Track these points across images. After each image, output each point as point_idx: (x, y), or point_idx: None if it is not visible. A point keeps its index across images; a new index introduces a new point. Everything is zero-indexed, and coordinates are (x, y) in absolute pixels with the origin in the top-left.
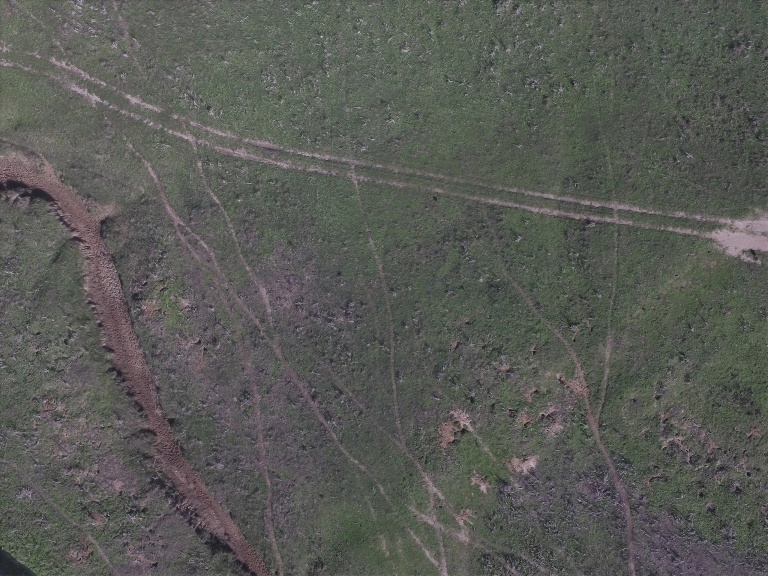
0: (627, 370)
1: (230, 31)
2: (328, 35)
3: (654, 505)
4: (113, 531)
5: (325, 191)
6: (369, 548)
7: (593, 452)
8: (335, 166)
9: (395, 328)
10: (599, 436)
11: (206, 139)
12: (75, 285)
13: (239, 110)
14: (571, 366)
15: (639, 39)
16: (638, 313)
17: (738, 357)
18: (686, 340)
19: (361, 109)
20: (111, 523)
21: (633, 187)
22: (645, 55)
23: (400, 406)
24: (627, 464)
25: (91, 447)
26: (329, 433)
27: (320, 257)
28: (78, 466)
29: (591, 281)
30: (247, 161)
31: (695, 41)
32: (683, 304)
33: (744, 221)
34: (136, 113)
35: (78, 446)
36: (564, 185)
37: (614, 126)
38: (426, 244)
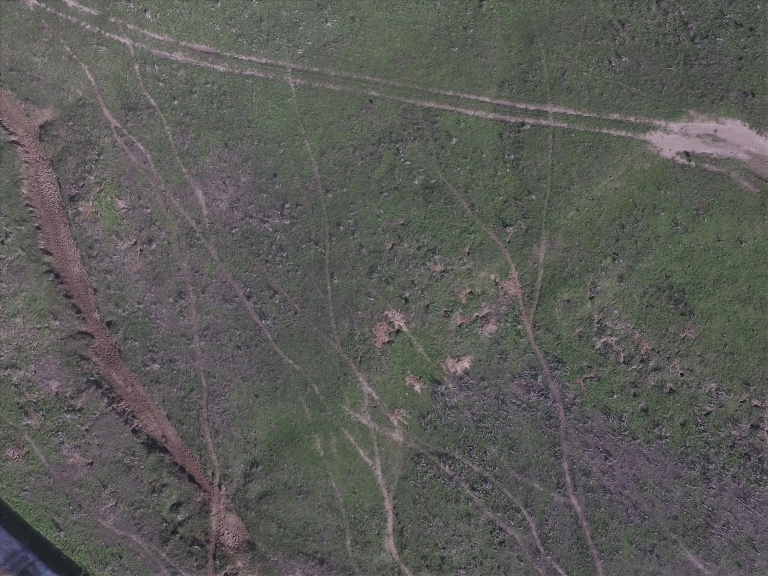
0: (561, 271)
1: None
2: None
3: (587, 405)
4: (49, 430)
5: (261, 94)
6: (304, 447)
7: (527, 352)
8: (272, 69)
9: (330, 229)
10: (533, 337)
11: (143, 42)
12: (13, 187)
13: (176, 13)
14: (505, 267)
15: None
16: (572, 214)
17: (672, 258)
18: (619, 240)
19: (298, 13)
20: (47, 422)
21: (568, 90)
22: None
23: (335, 307)
24: (560, 364)
25: (28, 348)
26: (264, 333)
27: (256, 159)
28: (15, 366)
29: (526, 183)
30: (184, 64)
31: None
32: (617, 205)
33: (678, 123)
34: (73, 16)
35: (15, 346)
36: (500, 88)
37: (550, 29)
38: (362, 146)
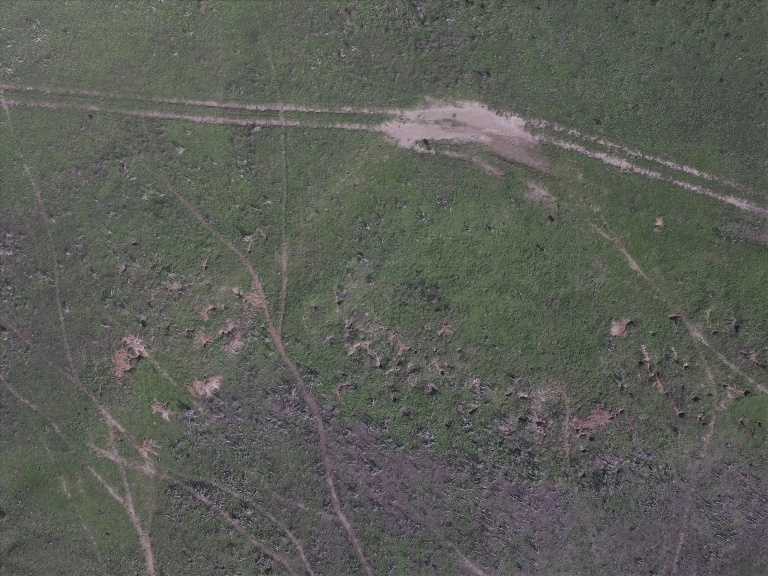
0: (305, 277)
1: None
2: None
3: (346, 415)
4: None
5: None
6: (49, 491)
7: (278, 366)
8: None
9: (58, 257)
10: (283, 349)
11: None
12: None
13: None
14: (247, 278)
15: None
16: (312, 216)
17: (421, 252)
18: (362, 239)
19: (5, 30)
20: None
21: (297, 86)
22: None
23: (69, 338)
24: (312, 374)
25: None
26: None
27: None
28: None
29: (261, 188)
30: None
31: None
32: (358, 202)
33: (415, 111)
34: None
35: None
36: (227, 91)
37: (274, 25)
38: (84, 165)
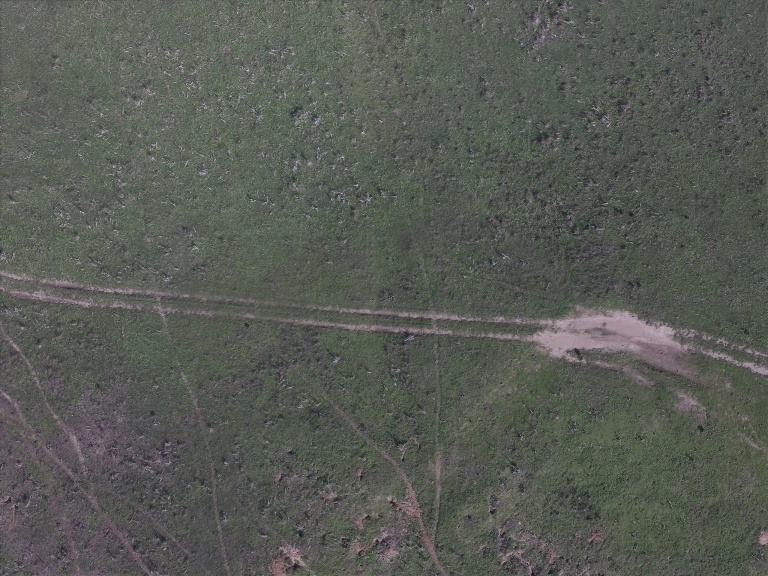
0: (459, 486)
1: (17, 169)
2: (121, 164)
3: None
4: None
5: (131, 327)
6: None
7: (432, 575)
8: (140, 300)
9: (215, 465)
10: (437, 557)
11: (0, 284)
12: None
13: (33, 251)
14: (401, 487)
15: (445, 140)
16: (465, 426)
17: (572, 461)
18: (516, 450)
19: (162, 238)
20: None
21: (450, 295)
22: (452, 156)
23: (227, 547)
24: None
25: None
26: None
27: (131, 398)
28: None
29: (415, 397)
30: (46, 303)
31: (503, 137)
32: (510, 412)
33: (566, 320)
34: None
35: None
36: (380, 298)
37: (426, 233)
38: (241, 374)
